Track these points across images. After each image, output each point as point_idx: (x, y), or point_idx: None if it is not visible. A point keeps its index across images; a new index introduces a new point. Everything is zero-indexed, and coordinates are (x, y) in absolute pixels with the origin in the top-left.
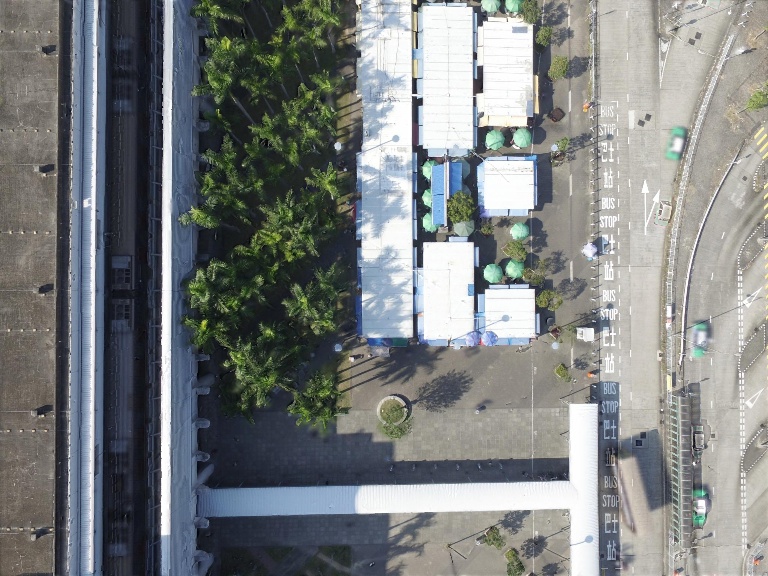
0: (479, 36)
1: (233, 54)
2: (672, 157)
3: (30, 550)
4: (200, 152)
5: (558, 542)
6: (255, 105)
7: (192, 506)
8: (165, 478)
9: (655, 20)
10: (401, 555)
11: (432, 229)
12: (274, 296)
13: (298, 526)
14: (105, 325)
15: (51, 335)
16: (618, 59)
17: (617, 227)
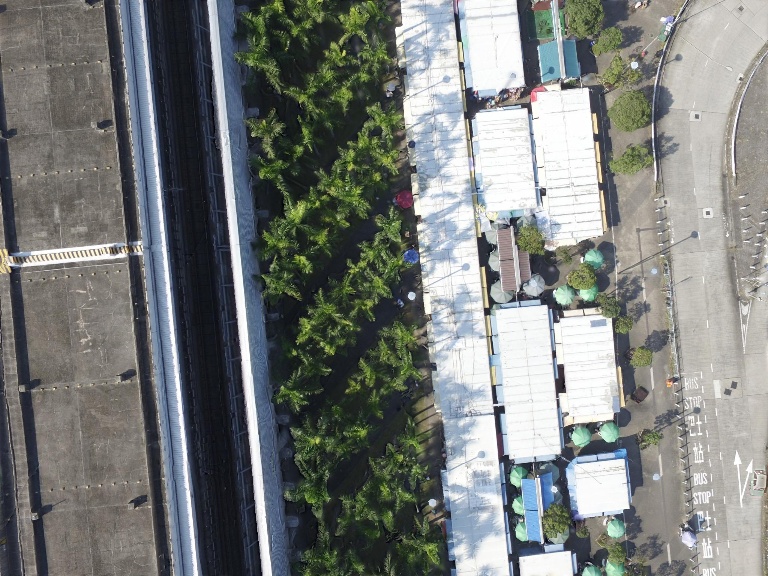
0: (556, 333)
1: (322, 447)
2: (762, 424)
3: None
4: (286, 511)
5: None
6: None
7: None
8: None
9: (733, 282)
10: None
11: (526, 540)
12: None
13: None
14: None
15: None
16: (698, 328)
17: (712, 503)
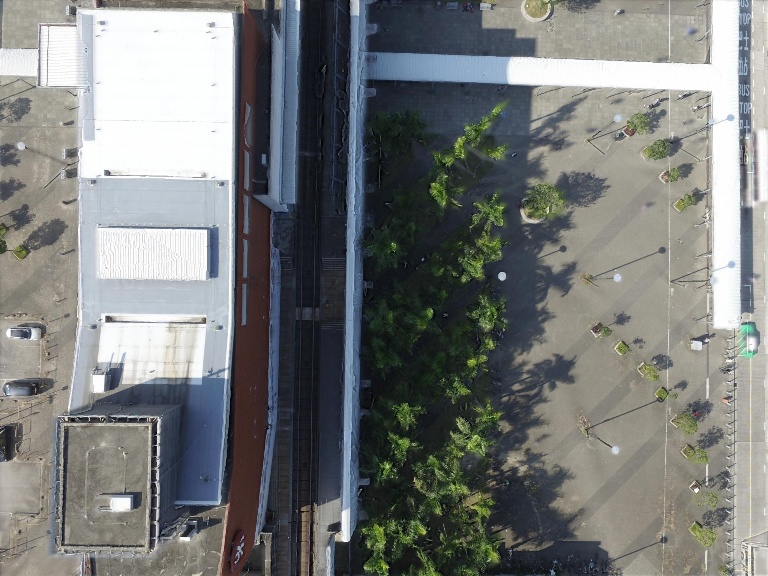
0: None
1: None
2: None
3: None
4: None
5: (692, 144)
6: None
7: None
8: None
9: None
10: (542, 147)
11: None
12: None
13: (444, 115)
14: None
15: None
16: None
17: None
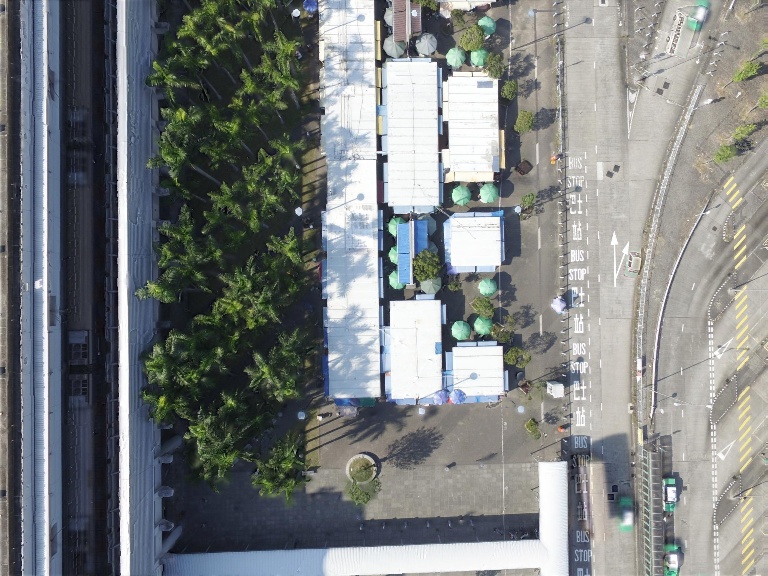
0: (444, 91)
1: (189, 125)
2: (641, 208)
3: None
4: (161, 217)
5: None
6: (216, 168)
7: (158, 573)
8: (124, 556)
9: (623, 70)
10: None
11: (399, 287)
12: (236, 364)
13: None
14: (62, 401)
15: (3, 419)
16: (586, 110)
17: (586, 280)
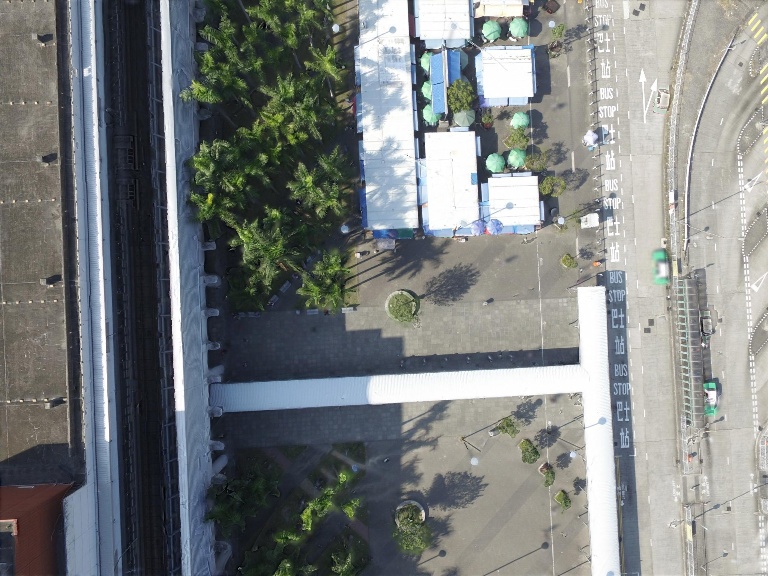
0: None
1: None
2: (668, 45)
3: (44, 421)
4: None
5: (571, 431)
6: None
7: (204, 400)
8: (177, 354)
9: None
10: (415, 450)
11: (433, 120)
12: (278, 179)
13: (311, 425)
14: (110, 205)
15: (56, 205)
16: None
17: (616, 117)
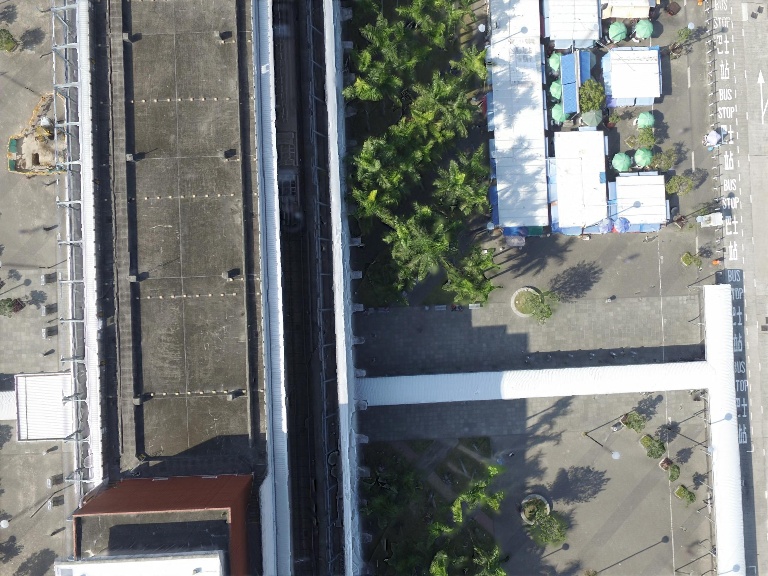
0: None
1: None
2: None
3: (224, 412)
4: None
5: (691, 427)
6: None
7: None
8: (341, 348)
9: None
10: (539, 444)
11: (561, 119)
12: (426, 176)
13: (438, 419)
14: None
15: (235, 200)
16: None
17: (735, 117)
